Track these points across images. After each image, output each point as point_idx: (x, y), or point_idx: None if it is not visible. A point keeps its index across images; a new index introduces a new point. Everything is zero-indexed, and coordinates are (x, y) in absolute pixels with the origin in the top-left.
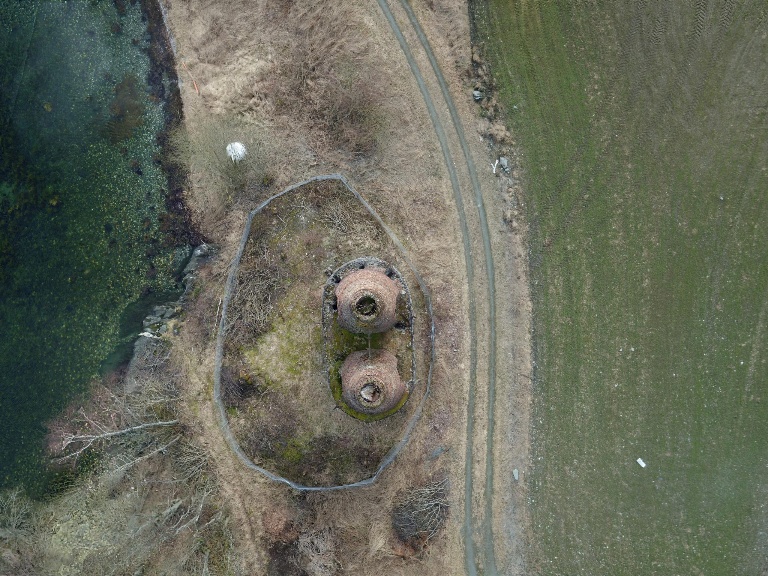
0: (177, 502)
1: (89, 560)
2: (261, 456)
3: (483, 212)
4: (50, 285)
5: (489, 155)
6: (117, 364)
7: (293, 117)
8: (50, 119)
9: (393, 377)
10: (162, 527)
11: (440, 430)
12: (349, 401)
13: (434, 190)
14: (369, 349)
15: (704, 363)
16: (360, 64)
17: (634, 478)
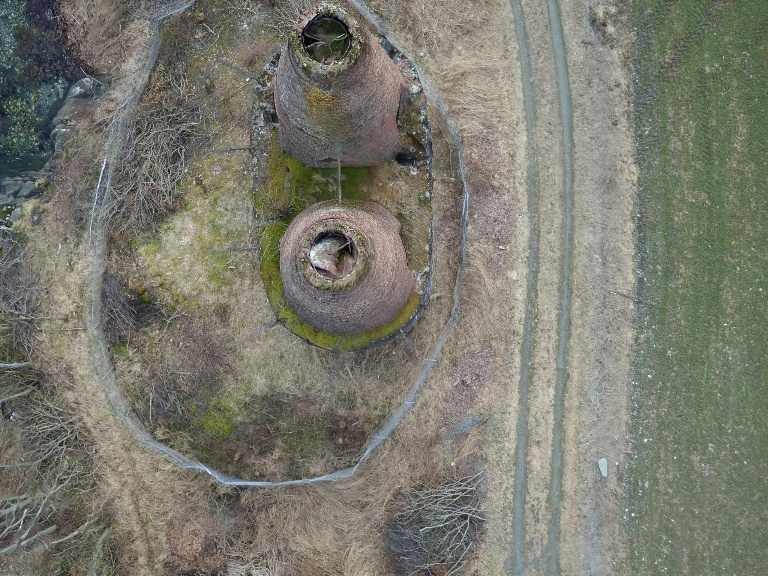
0: (21, 501)
1: None
2: (167, 426)
3: (555, 8)
4: None
5: None
6: None
7: None
8: None
9: (390, 241)
10: None
11: (471, 387)
12: (293, 297)
13: None
14: None
15: None
16: None
17: None
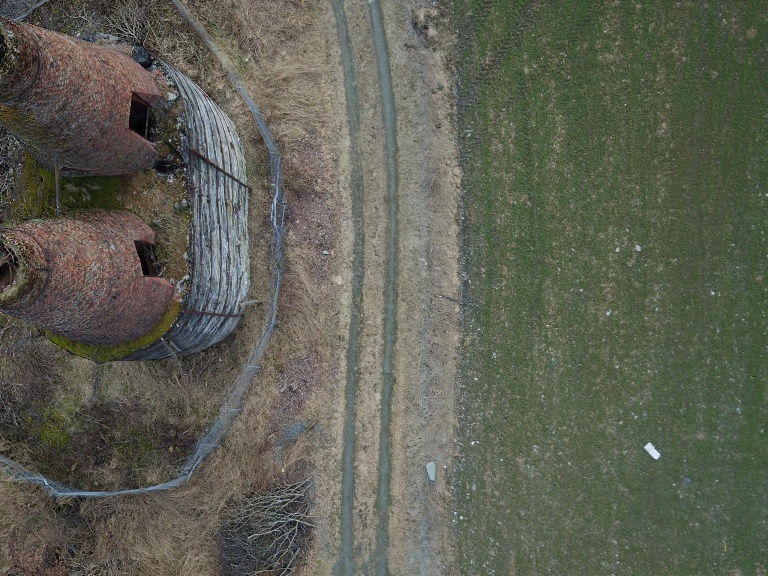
0: None
1: None
2: (7, 438)
3: (377, 12)
4: None
5: None
6: None
7: None
8: None
9: (101, 250)
10: None
11: (299, 392)
12: None
13: None
14: (56, 190)
15: (767, 271)
16: None
17: (639, 478)
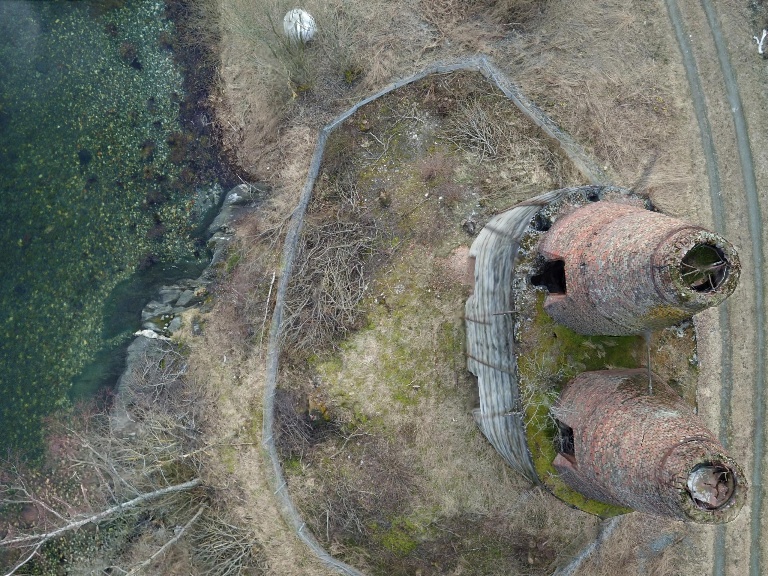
0: None
1: None
2: (342, 542)
3: (741, 121)
4: None
5: (750, 21)
6: (98, 382)
7: None
8: None
9: None
10: None
11: None
12: (597, 485)
13: (653, 82)
14: None
15: None
16: None
17: None
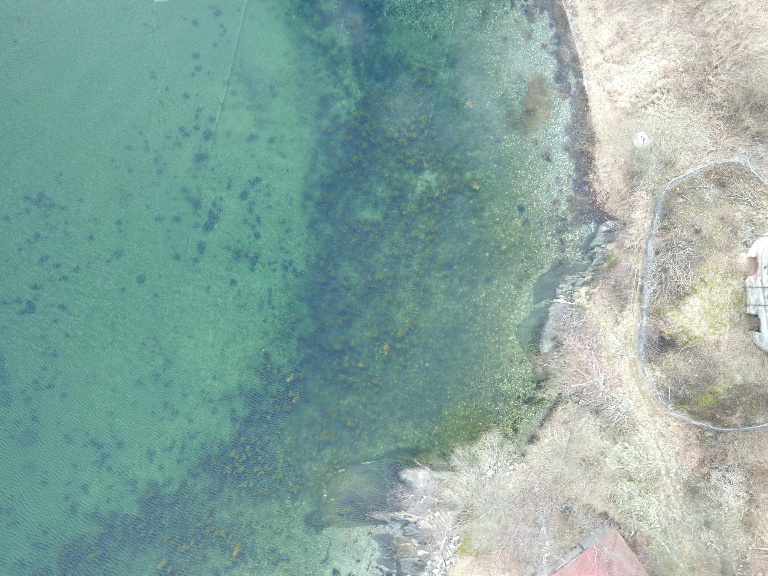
0: None
1: (520, 496)
2: (675, 403)
3: None
4: (471, 259)
5: None
6: (533, 327)
7: (693, 109)
8: (468, 114)
9: None
10: (587, 466)
11: None
12: None
13: None
14: None
15: None
16: (762, 62)
17: None
